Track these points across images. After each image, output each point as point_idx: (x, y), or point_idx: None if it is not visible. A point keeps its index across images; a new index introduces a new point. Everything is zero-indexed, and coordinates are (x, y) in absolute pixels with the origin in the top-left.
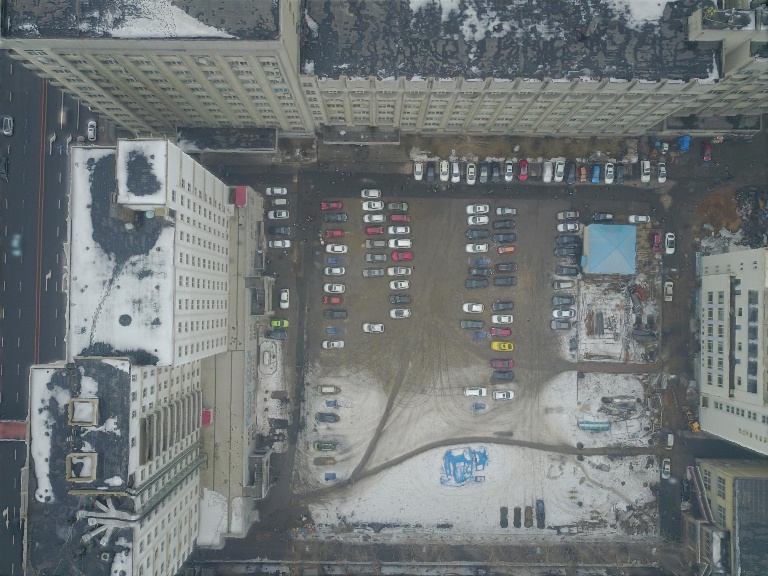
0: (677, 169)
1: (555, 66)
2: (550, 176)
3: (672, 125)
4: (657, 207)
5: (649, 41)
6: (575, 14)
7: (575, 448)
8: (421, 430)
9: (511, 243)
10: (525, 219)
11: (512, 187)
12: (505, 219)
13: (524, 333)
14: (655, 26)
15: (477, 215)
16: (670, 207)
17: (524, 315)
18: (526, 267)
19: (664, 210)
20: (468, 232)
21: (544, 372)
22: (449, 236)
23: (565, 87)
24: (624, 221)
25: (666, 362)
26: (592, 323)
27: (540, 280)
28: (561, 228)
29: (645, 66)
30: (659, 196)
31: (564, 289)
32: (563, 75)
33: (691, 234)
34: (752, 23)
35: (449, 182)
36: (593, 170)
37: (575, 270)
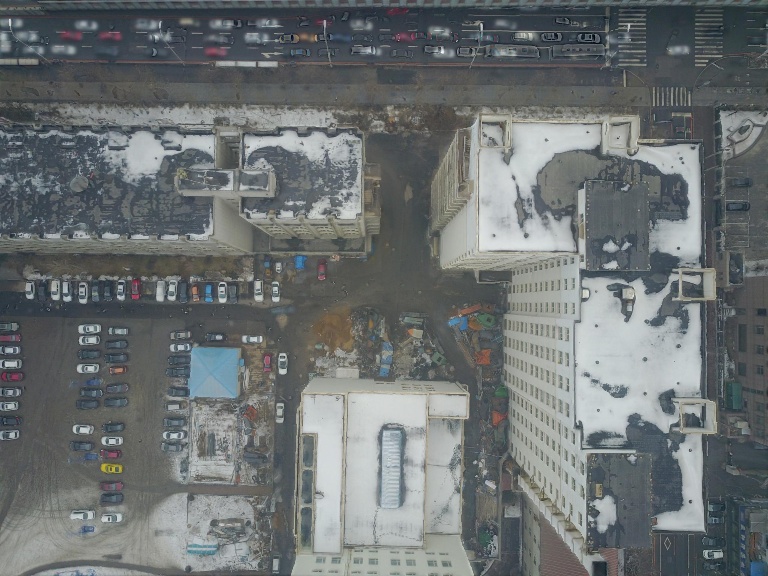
0: (294, 288)
1: (50, 221)
2: (162, 296)
3: (277, 247)
4: (272, 326)
5: (146, 195)
6: (71, 167)
7: (184, 571)
8: (29, 553)
9: (124, 363)
10: (139, 338)
11: (126, 306)
12: (117, 339)
13: (135, 454)
14: (152, 180)
15: (87, 335)
16: (285, 326)
17: (136, 436)
18: (139, 387)
19: (279, 329)
20: (79, 352)
21: (155, 494)
22: (62, 356)
23: (64, 241)
24: (239, 341)
25: (278, 484)
26: (204, 444)
27: (152, 401)
28: (172, 348)
29: (142, 221)
30: (275, 315)
31: (176, 410)
32: (58, 230)
33: (306, 354)
34: (231, 183)
35: (62, 301)
36: (205, 290)
37: (184, 392)
